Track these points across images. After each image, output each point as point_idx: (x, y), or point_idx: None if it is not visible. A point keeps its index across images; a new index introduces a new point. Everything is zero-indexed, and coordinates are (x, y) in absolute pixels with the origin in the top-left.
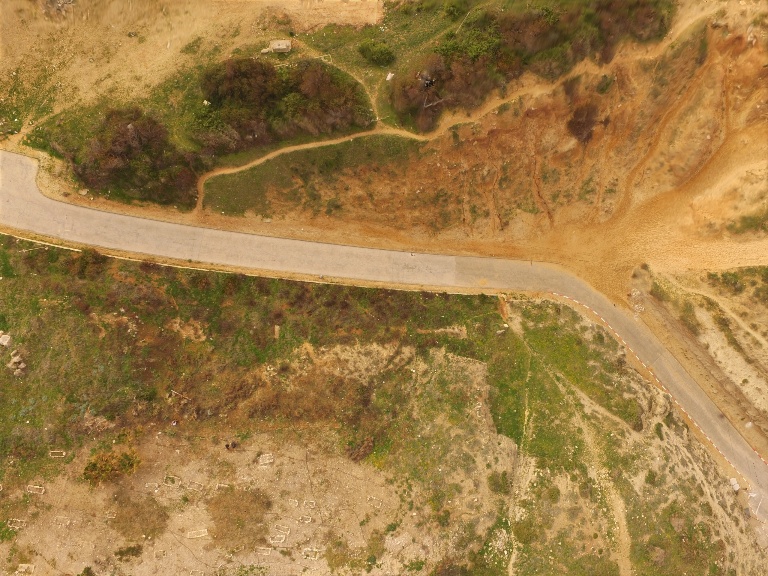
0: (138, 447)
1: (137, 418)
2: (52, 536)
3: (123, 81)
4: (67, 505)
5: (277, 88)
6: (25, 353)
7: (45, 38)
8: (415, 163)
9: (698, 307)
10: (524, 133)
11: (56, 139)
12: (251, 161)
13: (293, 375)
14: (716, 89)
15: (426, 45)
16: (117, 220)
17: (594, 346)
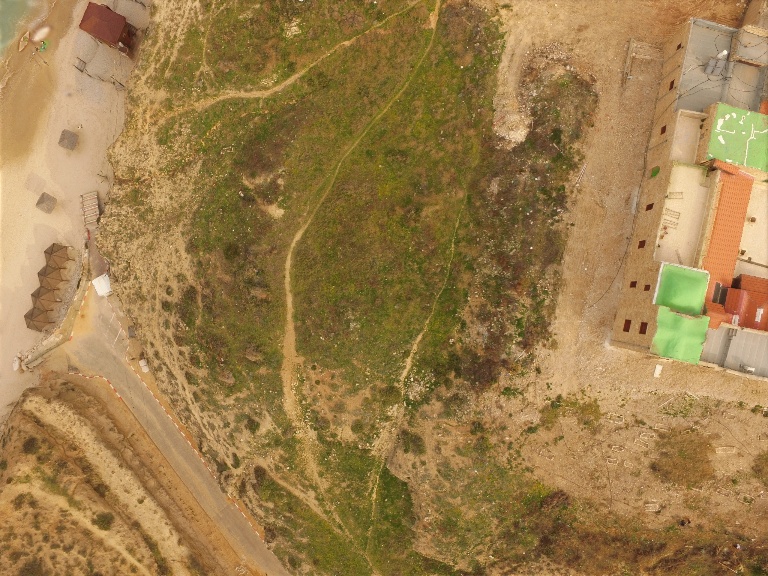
0: None
1: None
2: None
3: None
4: None
5: None
6: None
7: None
8: None
9: None
10: None
11: None
12: None
13: (617, 575)
14: None
15: None
16: None
17: (300, 556)
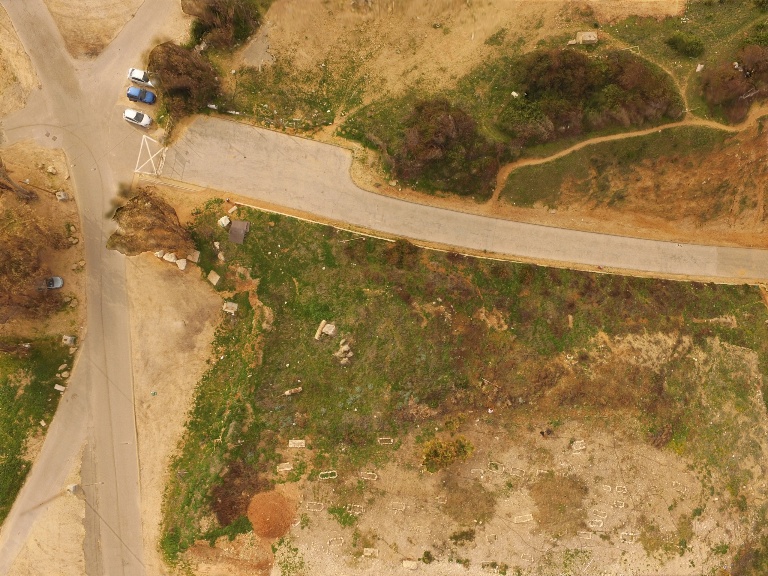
0: (459, 434)
1: (456, 406)
2: (390, 521)
3: (429, 72)
4: (400, 491)
5: (597, 79)
6: (352, 342)
7: (352, 29)
8: (714, 154)
9: None
10: None
11: (371, 130)
12: (557, 152)
13: (593, 363)
14: None
15: (734, 36)
16: (422, 211)
17: None
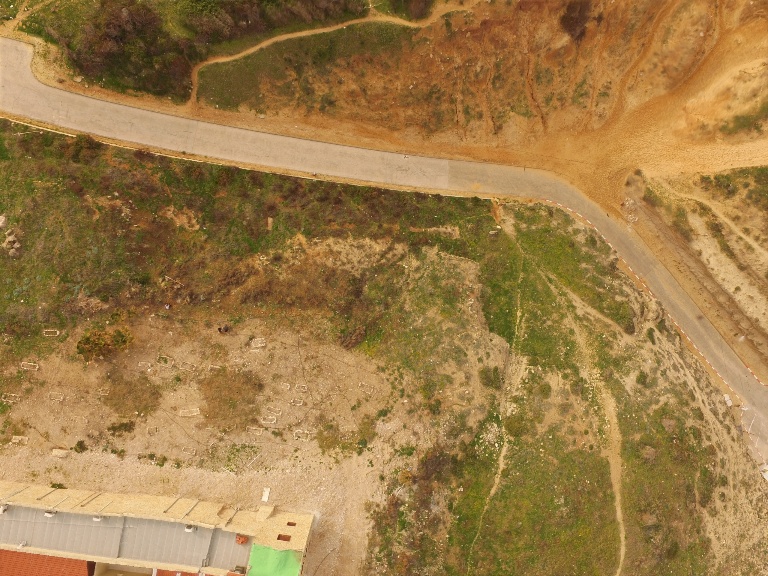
0: (131, 328)
1: (130, 300)
2: (46, 410)
3: None
4: (61, 382)
5: None
6: (20, 233)
7: None
8: (408, 54)
9: (691, 213)
10: (517, 27)
11: (51, 24)
12: (245, 49)
13: (286, 264)
14: None
15: None
16: (112, 109)
17: (586, 249)
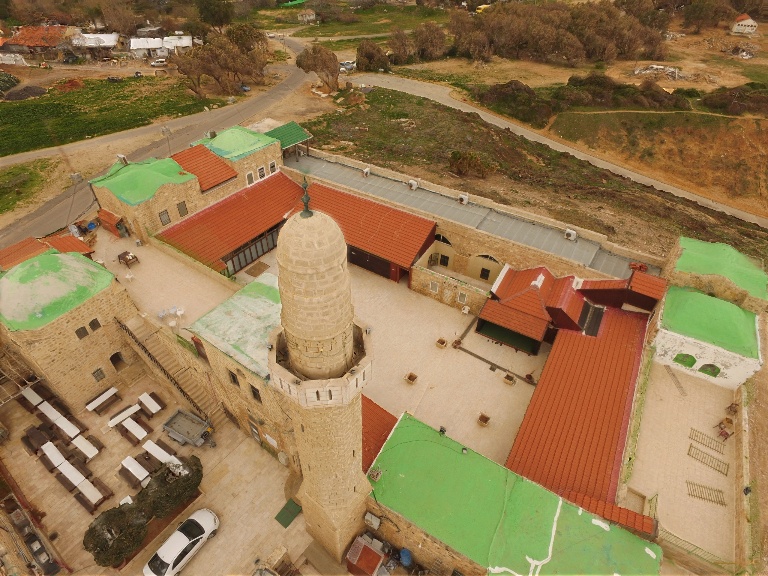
0: None
1: None
2: None
3: None
4: None
5: (623, 85)
6: (418, 123)
7: None
8: (723, 133)
9: None
10: None
11: None
12: (595, 111)
13: (625, 193)
14: None
15: None
16: None
17: None
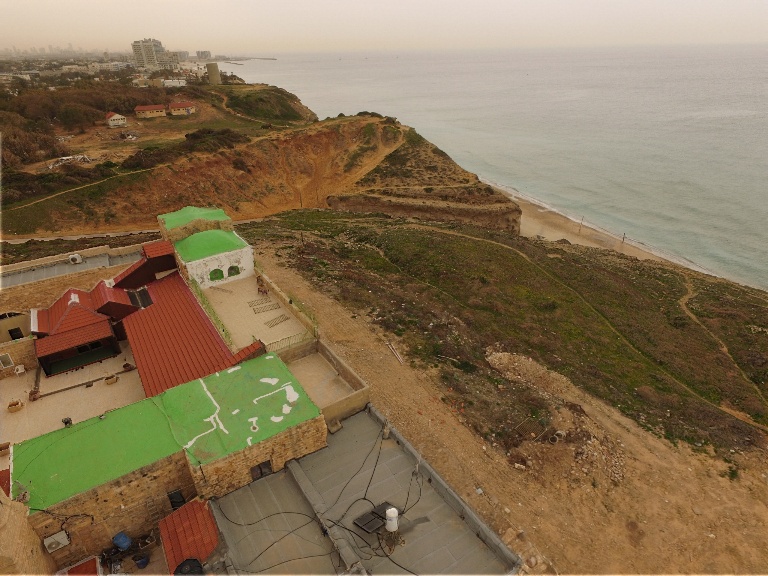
0: None
1: None
2: None
3: None
4: None
5: None
6: None
7: None
8: (153, 182)
9: None
10: None
11: None
12: (33, 202)
13: None
14: (290, 149)
15: None
16: None
17: None
